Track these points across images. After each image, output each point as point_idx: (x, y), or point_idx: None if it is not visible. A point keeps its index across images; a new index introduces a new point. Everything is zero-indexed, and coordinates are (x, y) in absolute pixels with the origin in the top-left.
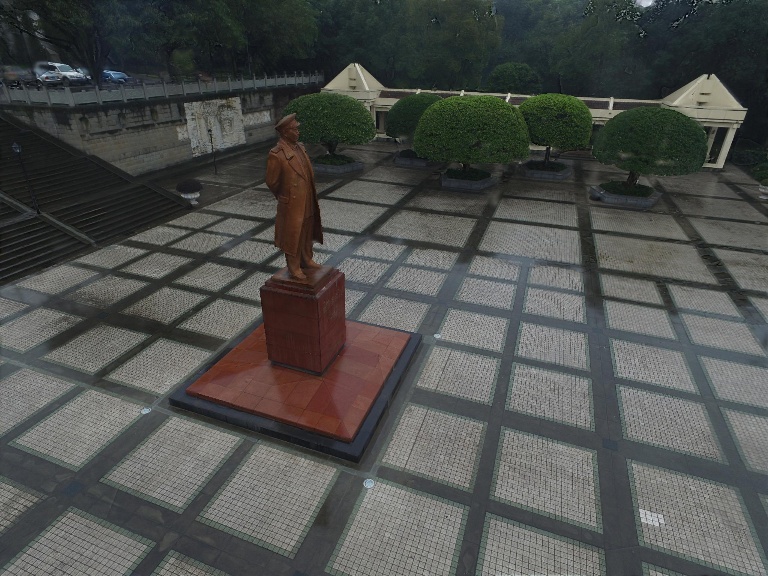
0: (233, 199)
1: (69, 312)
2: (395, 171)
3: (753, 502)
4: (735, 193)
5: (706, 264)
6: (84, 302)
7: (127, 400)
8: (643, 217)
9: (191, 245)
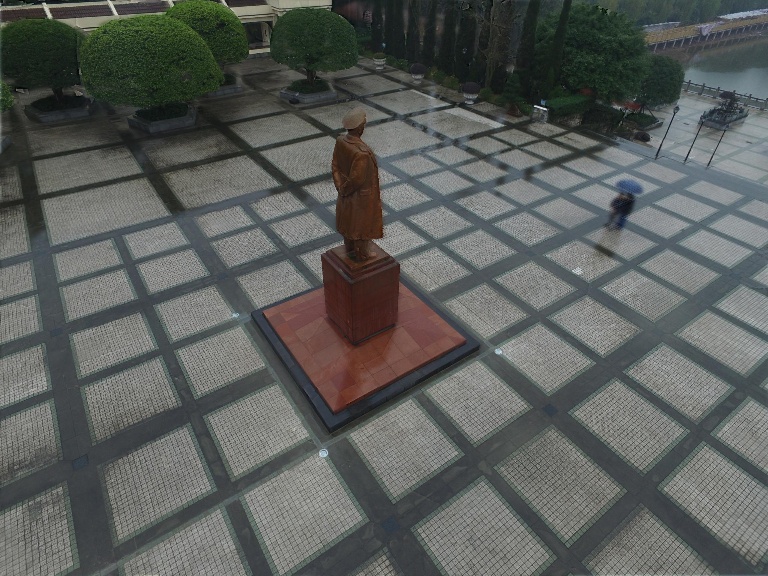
0: None
1: (19, 500)
2: (62, 132)
3: (585, 241)
4: (361, 69)
5: (421, 130)
6: (10, 479)
7: (293, 465)
8: (345, 108)
9: None
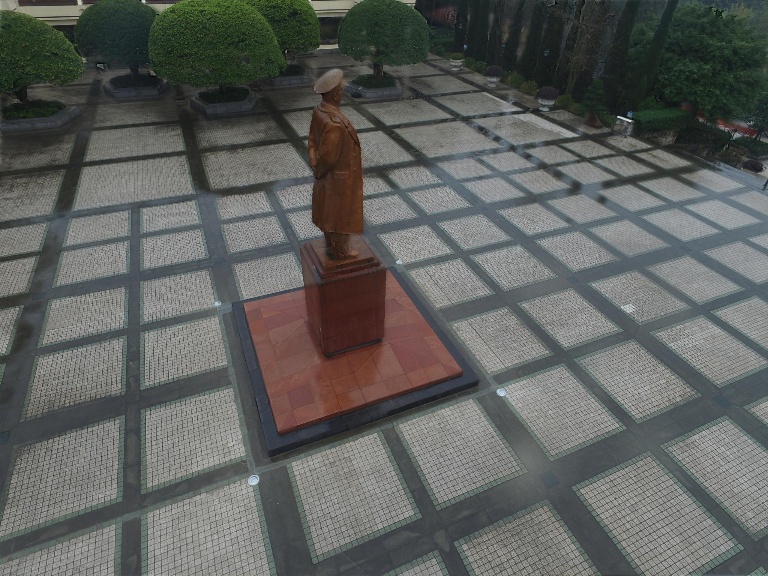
0: None
1: None
2: (129, 108)
3: (647, 273)
4: (436, 69)
5: (481, 133)
6: None
7: (215, 488)
8: (406, 105)
9: None
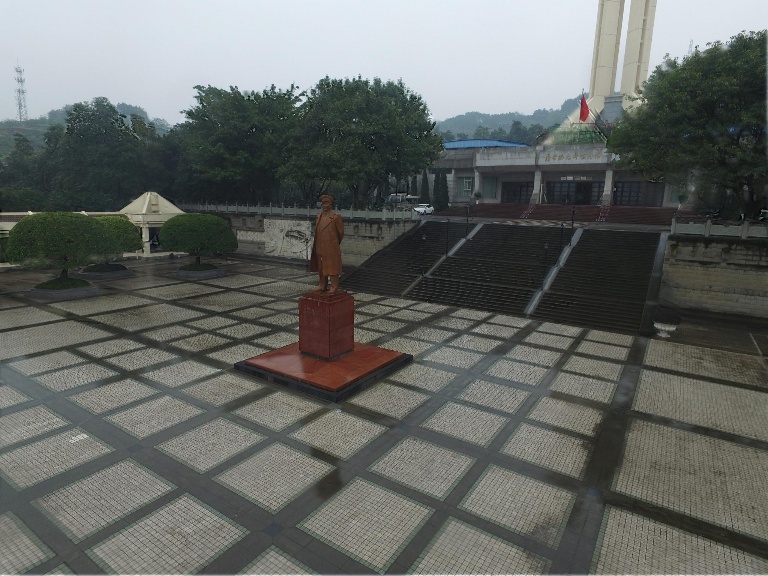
0: (703, 350)
1: None
2: None
3: (3, 491)
4: None
5: None
6: None
7: None
8: None
9: (540, 337)
